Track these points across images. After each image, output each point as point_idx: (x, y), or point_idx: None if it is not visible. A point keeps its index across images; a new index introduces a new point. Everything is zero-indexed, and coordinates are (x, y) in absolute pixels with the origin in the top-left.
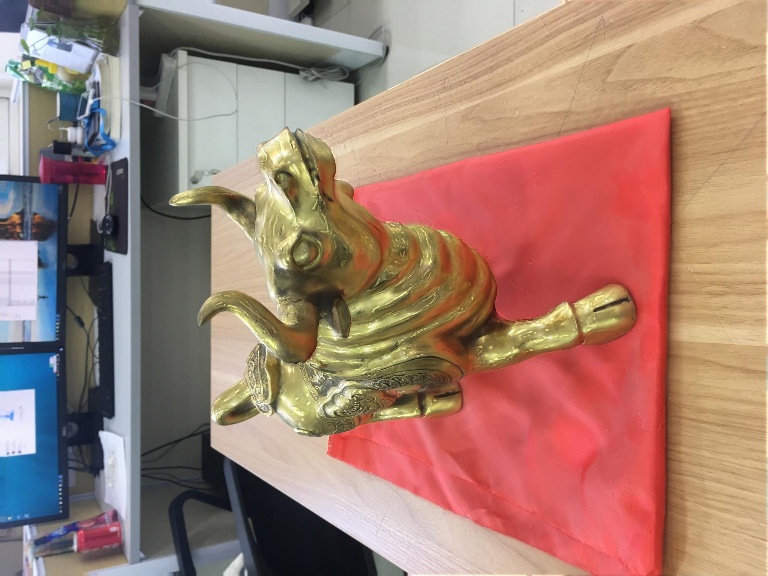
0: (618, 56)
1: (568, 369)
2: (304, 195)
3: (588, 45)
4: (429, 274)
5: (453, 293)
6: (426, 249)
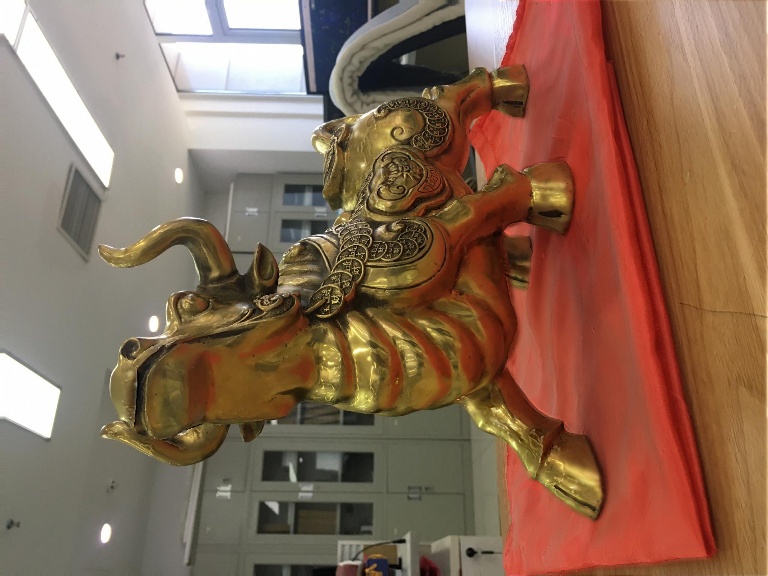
0: (767, 400)
1: None
2: None
3: None
4: (364, 408)
5: None
6: (365, 392)
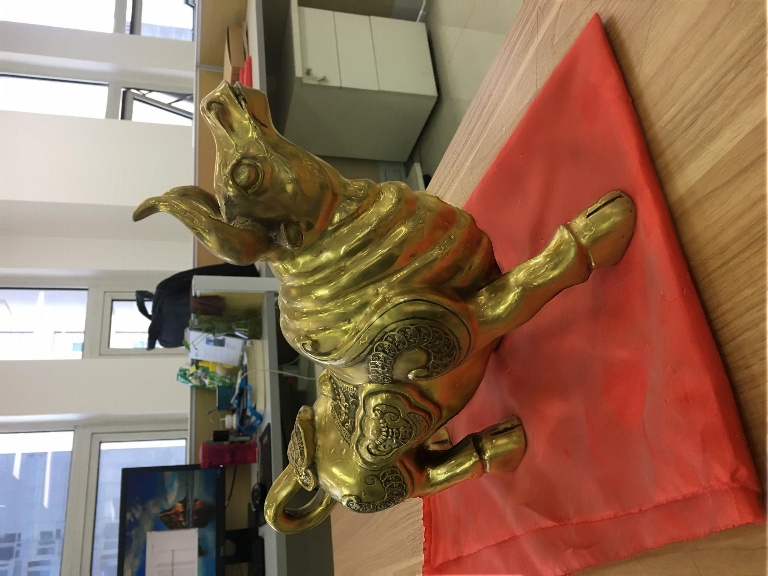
0: (556, 20)
1: (598, 314)
2: (238, 123)
3: (535, 33)
4: (392, 209)
5: (425, 227)
6: (389, 192)
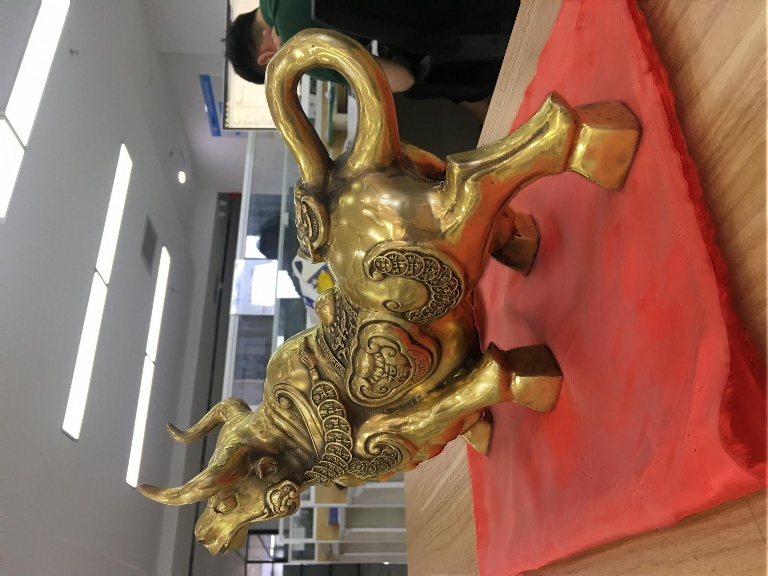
0: None
1: None
2: None
3: None
4: None
5: None
6: None
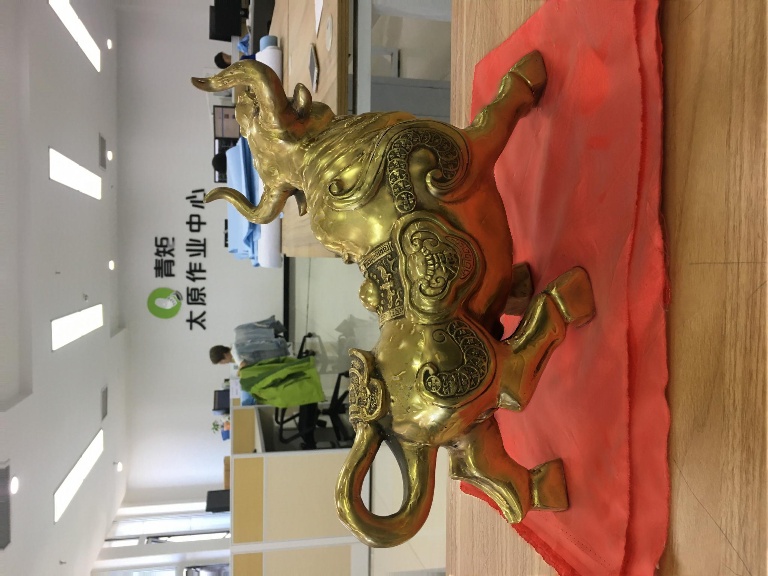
0: None
1: (555, 109)
2: None
3: None
4: None
5: None
6: None
